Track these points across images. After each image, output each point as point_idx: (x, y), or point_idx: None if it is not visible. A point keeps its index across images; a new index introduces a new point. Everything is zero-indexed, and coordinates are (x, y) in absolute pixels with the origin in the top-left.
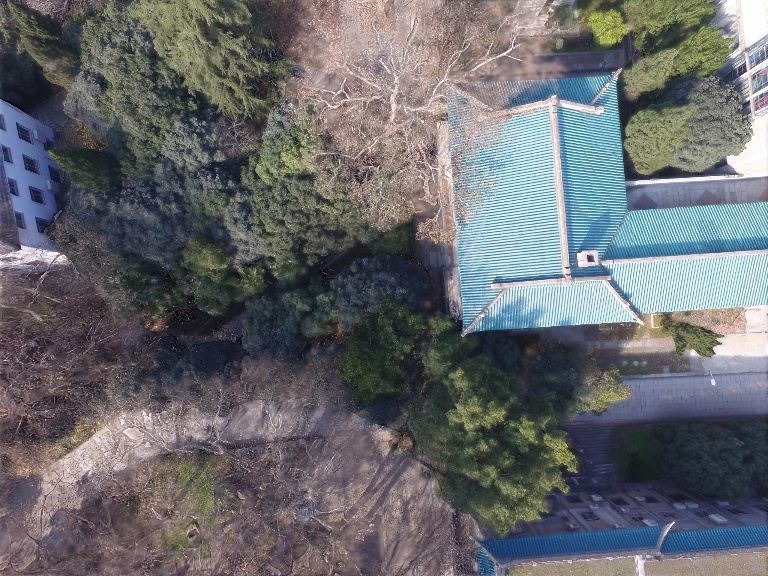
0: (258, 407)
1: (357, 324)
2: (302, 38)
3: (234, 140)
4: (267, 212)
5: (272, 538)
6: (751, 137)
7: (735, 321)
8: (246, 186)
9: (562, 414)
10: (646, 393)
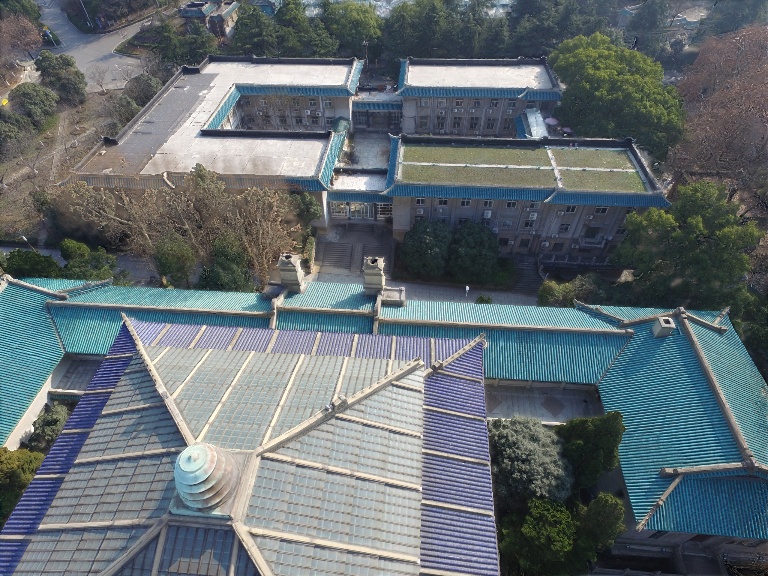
0: None
1: None
2: None
3: None
4: None
5: (752, 265)
6: None
7: None
8: None
9: None
10: None
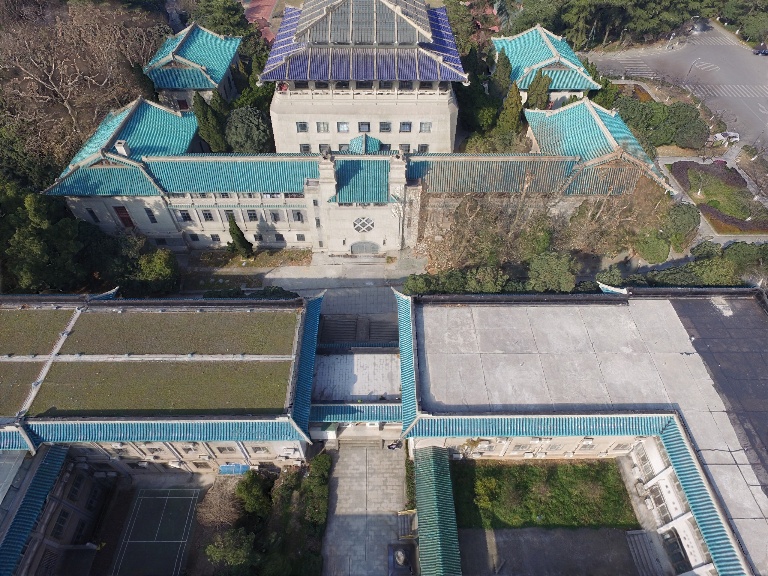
0: None
1: None
2: None
3: None
4: None
5: None
6: None
7: (304, 259)
8: None
9: (107, 263)
10: None
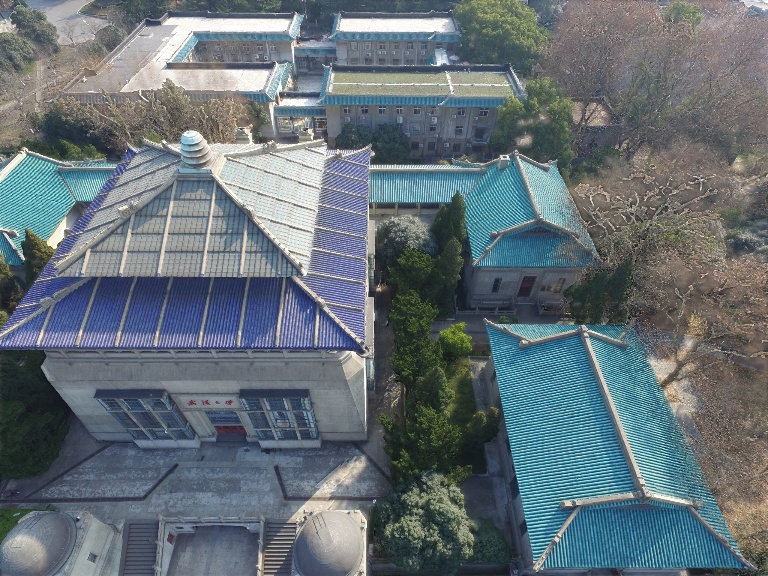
0: None
1: None
2: (723, 375)
3: None
4: None
5: None
6: None
7: None
8: None
9: None
10: None
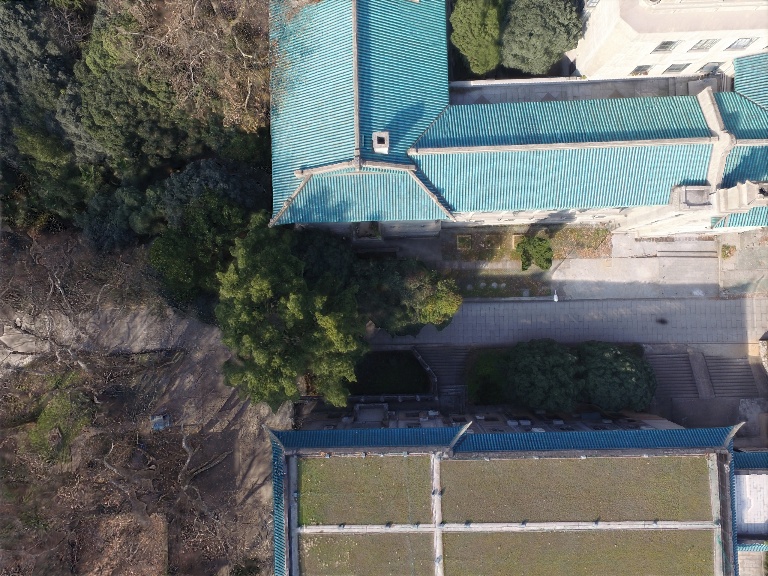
0: (125, 319)
1: (185, 221)
2: None
3: (68, 32)
4: (95, 103)
5: None
6: (589, 33)
7: (600, 245)
8: (79, 79)
9: (388, 320)
10: (505, 317)
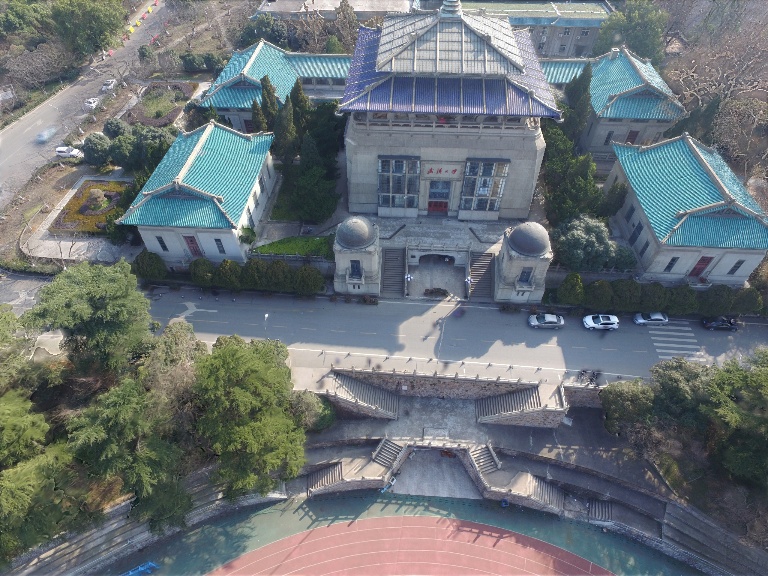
0: None
1: None
2: None
3: None
4: None
5: None
6: None
7: None
8: None
9: None
10: None
